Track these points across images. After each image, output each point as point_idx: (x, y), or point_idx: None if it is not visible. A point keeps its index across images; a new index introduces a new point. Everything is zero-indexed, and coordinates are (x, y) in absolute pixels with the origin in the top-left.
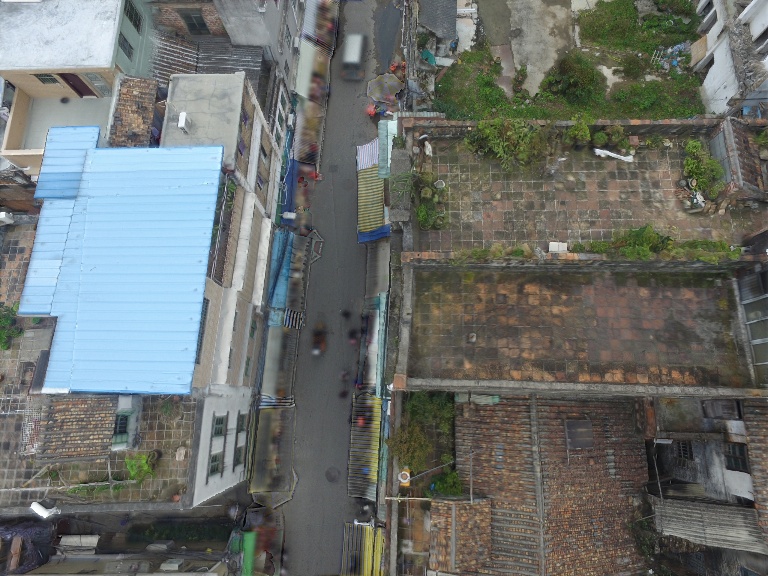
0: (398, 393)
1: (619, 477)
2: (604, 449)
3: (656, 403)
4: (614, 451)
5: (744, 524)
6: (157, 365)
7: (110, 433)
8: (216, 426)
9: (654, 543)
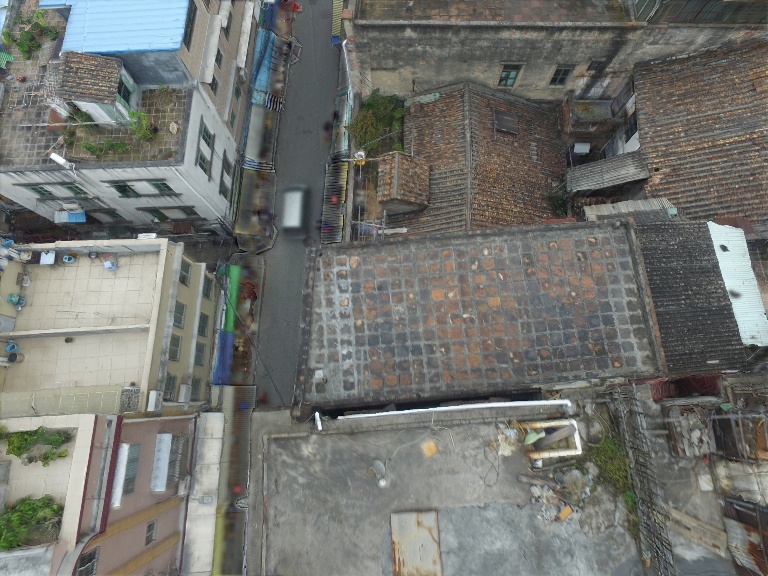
0: (356, 97)
1: (540, 163)
2: (528, 141)
3: (570, 97)
4: (537, 144)
5: (632, 163)
6: (154, 32)
7: (115, 85)
8: (204, 134)
9: (567, 208)
